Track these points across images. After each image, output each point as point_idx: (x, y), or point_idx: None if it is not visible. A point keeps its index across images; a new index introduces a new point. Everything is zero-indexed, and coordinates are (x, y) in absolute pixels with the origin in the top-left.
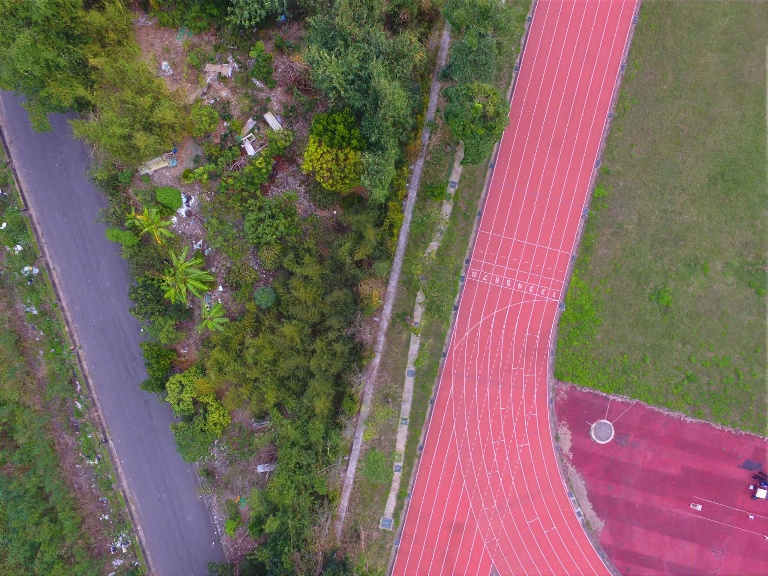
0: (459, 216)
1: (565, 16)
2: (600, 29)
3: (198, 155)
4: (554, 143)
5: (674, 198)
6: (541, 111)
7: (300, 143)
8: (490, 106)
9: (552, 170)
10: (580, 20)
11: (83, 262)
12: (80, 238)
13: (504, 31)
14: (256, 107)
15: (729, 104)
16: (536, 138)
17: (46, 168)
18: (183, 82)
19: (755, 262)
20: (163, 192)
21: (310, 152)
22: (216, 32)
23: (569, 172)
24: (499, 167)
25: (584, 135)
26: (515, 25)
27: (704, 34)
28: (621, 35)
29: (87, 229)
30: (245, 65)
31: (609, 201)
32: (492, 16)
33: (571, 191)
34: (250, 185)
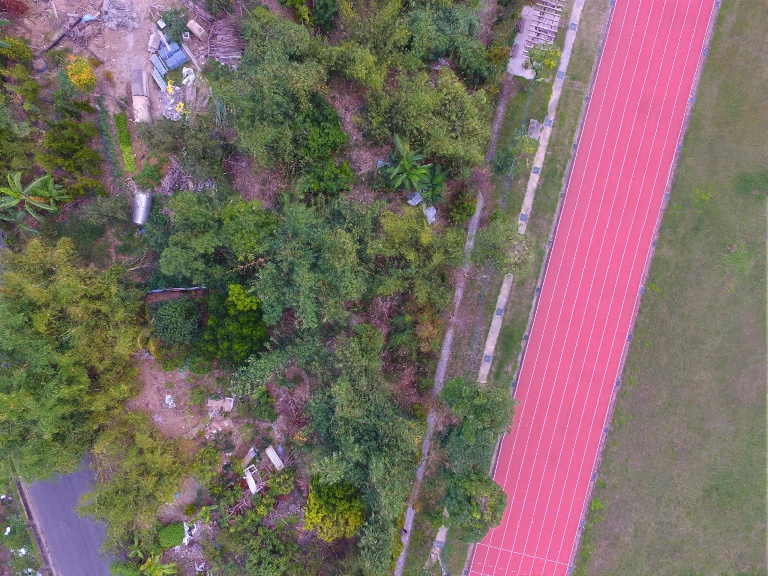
0: (458, 529)
1: (561, 334)
2: (595, 347)
3: (200, 491)
4: (551, 457)
5: (669, 511)
6: (538, 426)
7: (301, 469)
8: (487, 510)
9: (549, 484)
10: (576, 338)
11: (86, 570)
12: (83, 546)
13: (501, 423)
14: (258, 436)
15: (723, 419)
16: (533, 453)
17: (50, 480)
18: (186, 414)
19: (750, 573)
20: (166, 536)
21: (311, 517)
22: (219, 365)
23: (566, 485)
24: (497, 481)
25: (580, 449)
26: (512, 410)
27: (697, 352)
28: (616, 352)
29: (90, 538)
30: (247, 401)
31: (605, 514)
32: (489, 408)
33: (568, 504)
34: (252, 524)
